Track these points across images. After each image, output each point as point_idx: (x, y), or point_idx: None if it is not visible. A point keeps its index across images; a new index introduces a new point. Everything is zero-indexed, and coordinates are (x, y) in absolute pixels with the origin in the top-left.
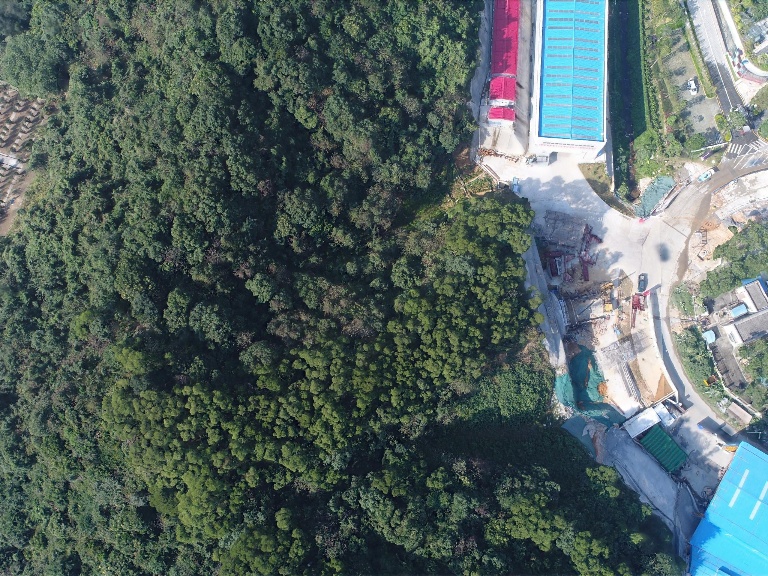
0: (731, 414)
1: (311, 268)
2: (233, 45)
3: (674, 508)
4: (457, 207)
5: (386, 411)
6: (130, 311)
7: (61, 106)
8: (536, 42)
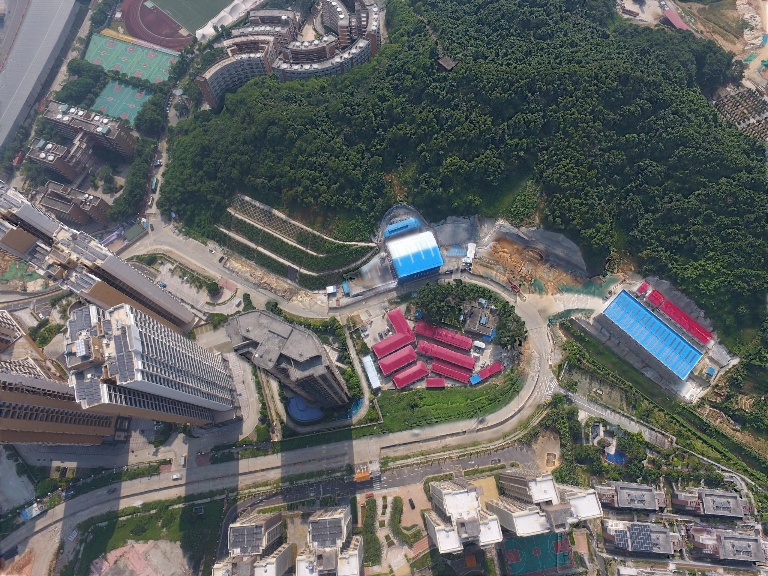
0: None
1: None
2: None
3: (437, 232)
4: None
5: (561, 138)
6: None
7: None
8: None
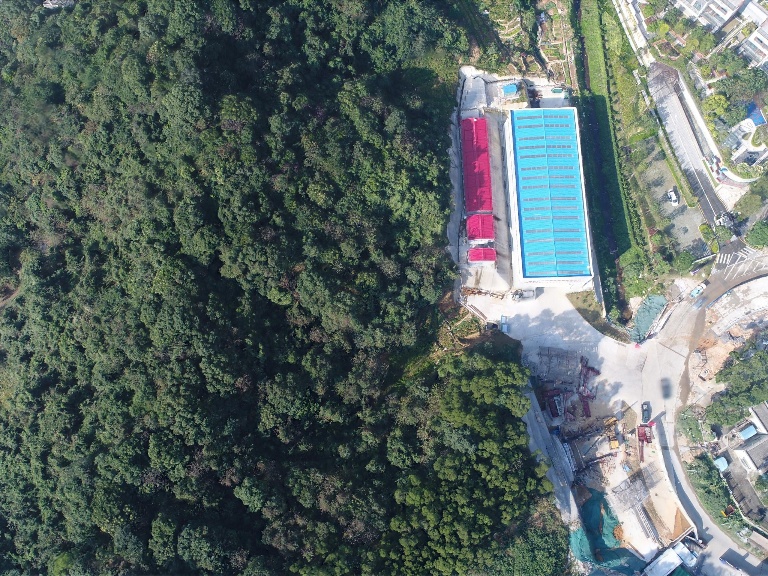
0: (753, 544)
1: (301, 454)
2: (194, 237)
3: None
4: (448, 367)
5: None
6: (112, 544)
7: (15, 299)
8: (508, 170)
